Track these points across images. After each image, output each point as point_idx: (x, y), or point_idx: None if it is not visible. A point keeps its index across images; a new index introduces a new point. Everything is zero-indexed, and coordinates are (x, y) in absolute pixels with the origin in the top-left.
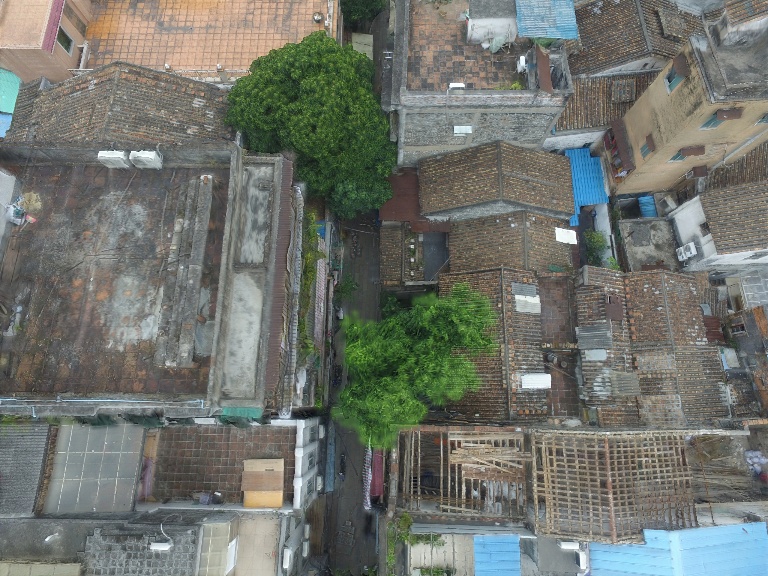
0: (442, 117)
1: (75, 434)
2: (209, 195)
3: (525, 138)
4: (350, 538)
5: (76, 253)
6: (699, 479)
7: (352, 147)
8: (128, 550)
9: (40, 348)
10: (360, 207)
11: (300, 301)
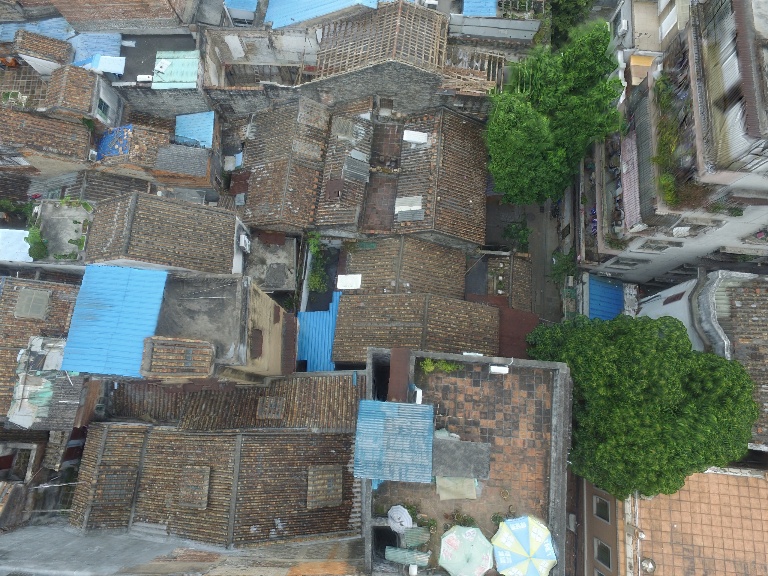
0: None
1: None
2: None
3: None
4: None
5: None
6: None
7: None
8: None
9: None
10: None
11: None
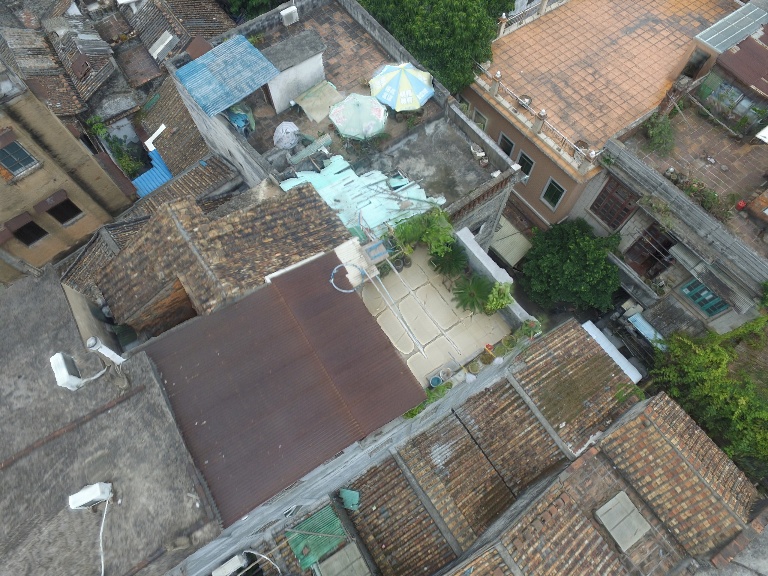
0: None
1: None
2: None
3: None
4: None
5: None
6: None
7: None
8: None
9: None
10: None
11: None
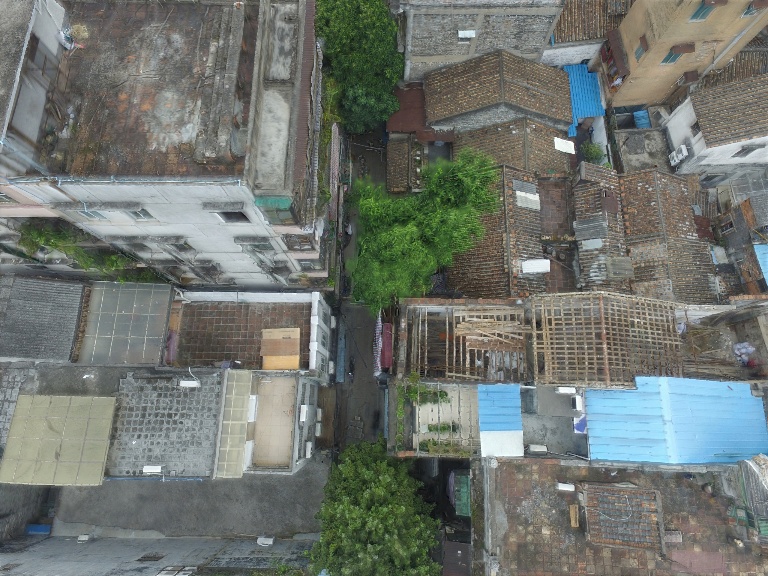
0: (447, 20)
1: (106, 297)
2: (242, 18)
3: (526, 46)
4: (359, 432)
5: (121, 74)
6: (690, 368)
7: (363, 46)
8: (159, 391)
9: (91, 150)
10: (369, 118)
11: (319, 149)
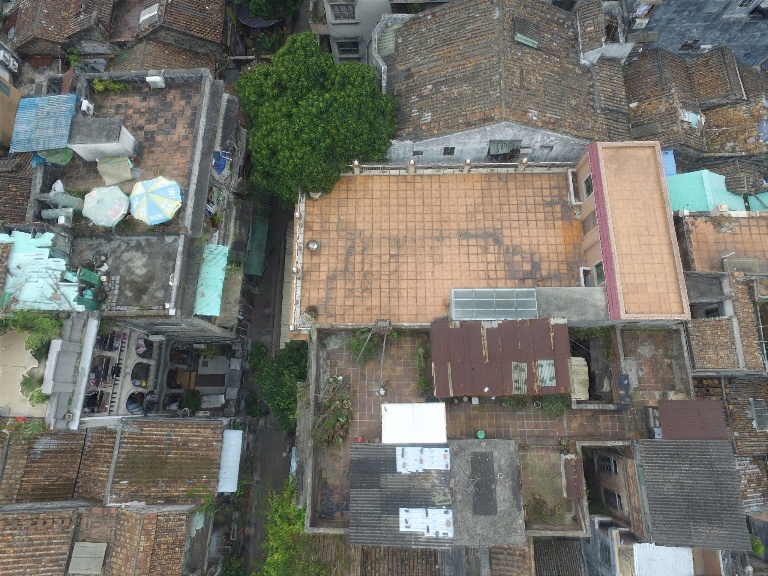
0: None
1: None
2: None
3: None
4: None
5: None
6: None
7: None
8: None
9: None
10: None
11: None
